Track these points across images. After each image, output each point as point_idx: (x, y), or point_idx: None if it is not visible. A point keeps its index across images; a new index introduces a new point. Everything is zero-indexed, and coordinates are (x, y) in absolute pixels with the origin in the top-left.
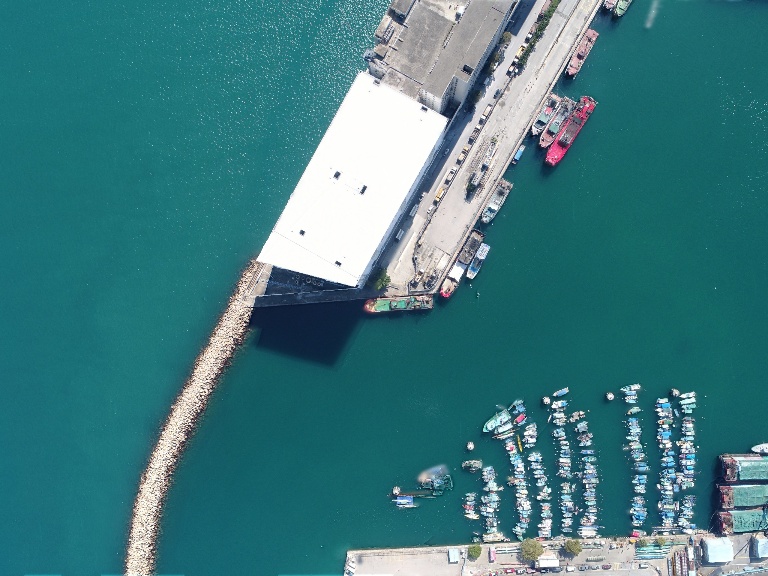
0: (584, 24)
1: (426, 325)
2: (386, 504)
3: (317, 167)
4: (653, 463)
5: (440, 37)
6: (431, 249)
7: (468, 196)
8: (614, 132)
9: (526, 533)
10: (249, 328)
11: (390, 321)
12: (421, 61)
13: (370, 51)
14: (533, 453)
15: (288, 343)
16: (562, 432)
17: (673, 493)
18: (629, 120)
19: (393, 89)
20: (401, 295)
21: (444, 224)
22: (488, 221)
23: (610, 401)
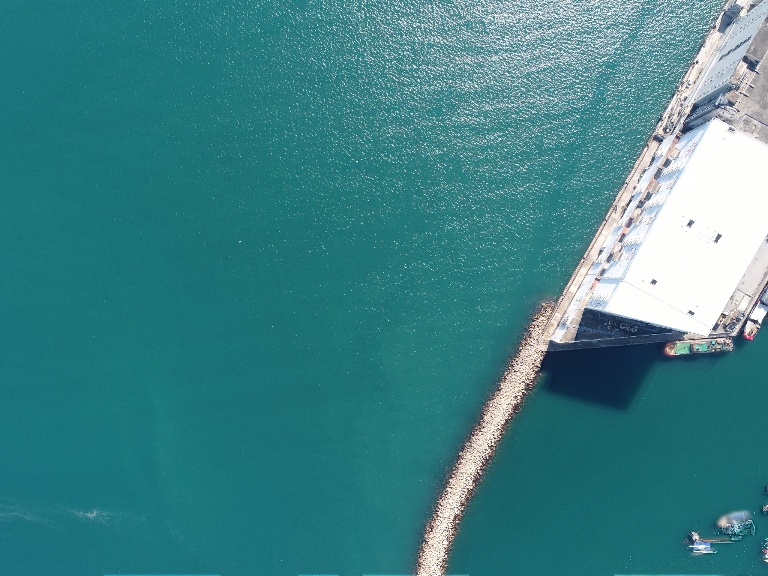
0: None
1: (724, 367)
2: (682, 550)
3: (670, 215)
4: None
5: None
6: None
7: None
8: None
9: None
10: (540, 373)
11: (686, 364)
12: None
13: (723, 98)
14: None
15: (580, 387)
16: None
17: None
18: None
19: (748, 136)
20: (700, 338)
21: None
22: None
23: None
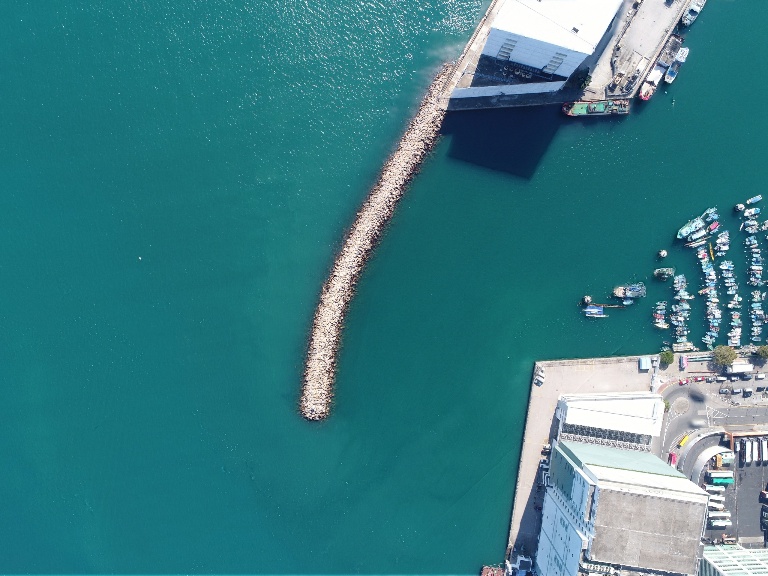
0: None
1: (620, 132)
2: (575, 314)
3: None
4: None
5: None
6: (629, 53)
7: None
8: None
9: (716, 342)
10: (440, 133)
11: (584, 128)
12: None
13: None
14: (725, 261)
15: (479, 149)
16: (754, 240)
17: None
18: None
19: None
20: (598, 99)
21: (643, 28)
22: (689, 24)
23: None
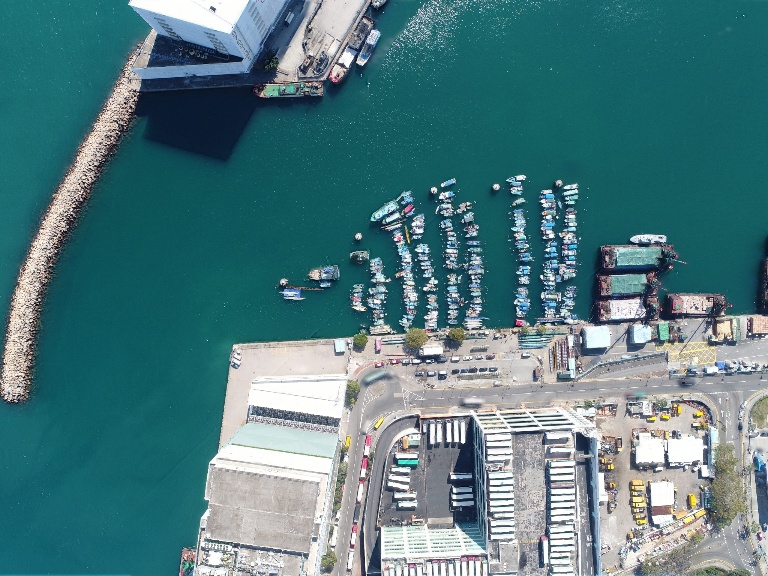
0: None
1: (316, 114)
2: (273, 297)
3: None
4: (537, 255)
5: None
6: (321, 35)
7: None
8: None
9: (412, 325)
10: (135, 114)
11: (280, 110)
12: None
13: None
14: (420, 244)
15: (175, 131)
16: (449, 223)
17: (556, 284)
18: None
19: None
20: (291, 81)
21: (335, 10)
22: (378, 6)
23: (496, 192)
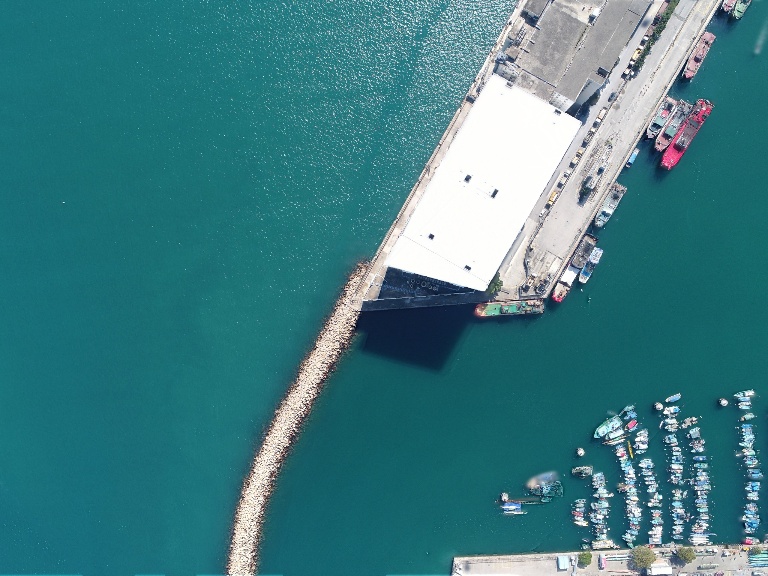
0: (701, 27)
1: (536, 330)
2: (493, 510)
3: (447, 170)
4: (766, 470)
5: (573, 39)
6: (543, 253)
7: (581, 200)
8: (729, 136)
9: (636, 540)
10: (355, 332)
11: (499, 326)
12: (553, 63)
13: (502, 53)
14: (644, 459)
15: (395, 347)
16: (674, 438)
17: None
18: (745, 124)
19: (526, 92)
20: (511, 299)
21: (556, 228)
22: (602, 225)
23: (723, 407)
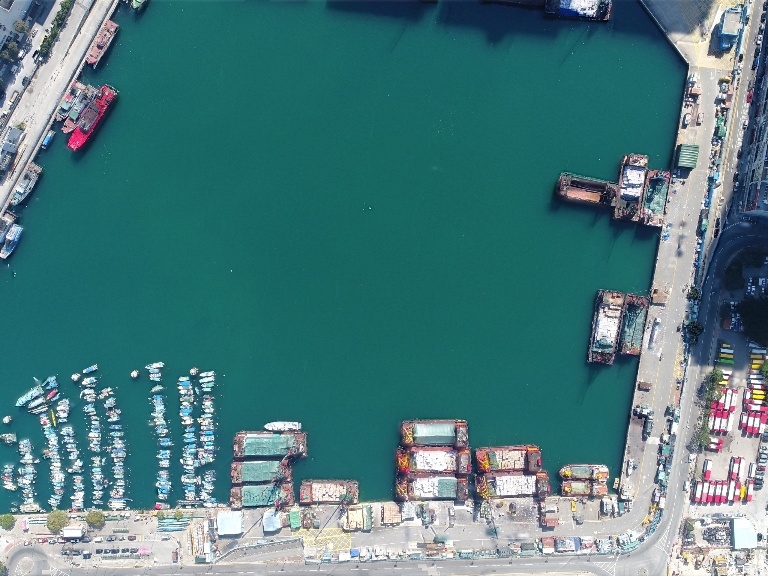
0: (104, 15)
1: None
2: None
3: None
4: (177, 439)
5: None
6: None
7: (0, 179)
8: (137, 120)
9: (60, 504)
10: None
11: None
12: None
13: None
14: (65, 427)
15: None
16: (91, 408)
17: (195, 468)
18: (151, 108)
19: None
20: None
21: None
22: (16, 203)
23: (136, 379)
